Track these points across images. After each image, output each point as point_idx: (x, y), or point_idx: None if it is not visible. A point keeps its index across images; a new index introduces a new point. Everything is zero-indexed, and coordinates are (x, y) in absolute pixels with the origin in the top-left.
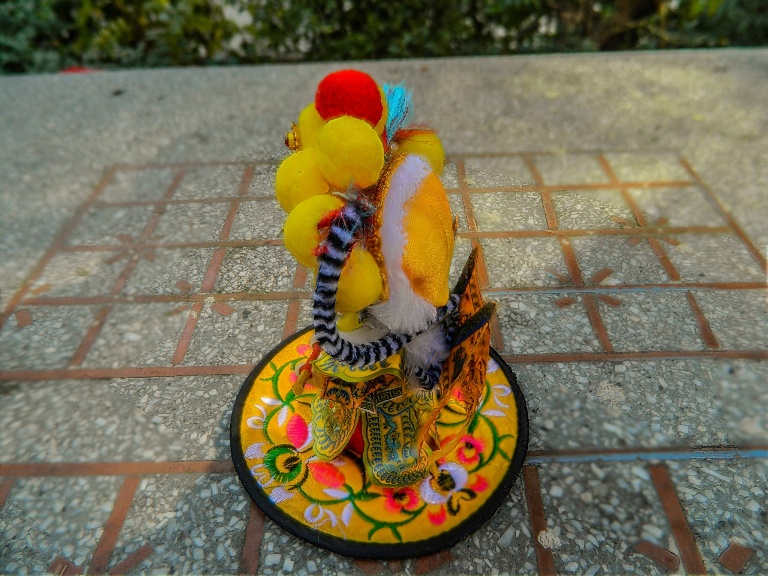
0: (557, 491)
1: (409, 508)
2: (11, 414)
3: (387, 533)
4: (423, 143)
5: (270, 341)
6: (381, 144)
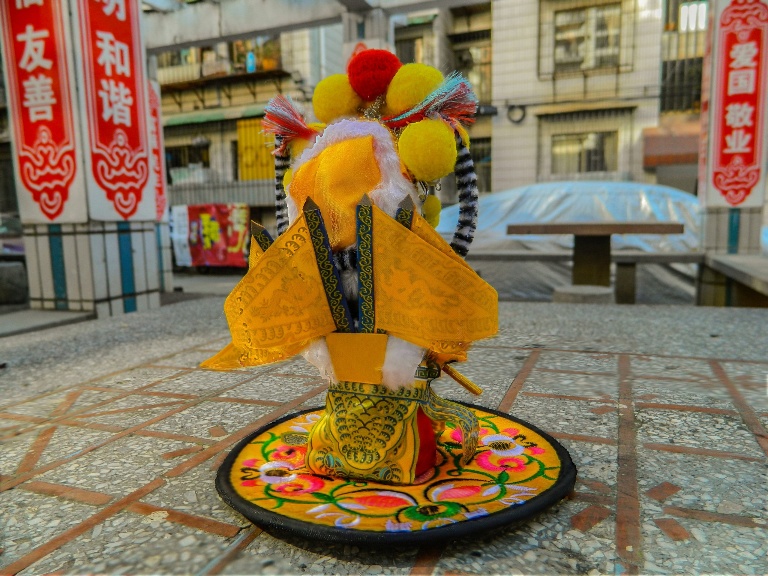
0: (187, 541)
1: (274, 453)
2: (494, 360)
3: (264, 438)
4: (409, 124)
5: (539, 425)
6: (325, 88)
